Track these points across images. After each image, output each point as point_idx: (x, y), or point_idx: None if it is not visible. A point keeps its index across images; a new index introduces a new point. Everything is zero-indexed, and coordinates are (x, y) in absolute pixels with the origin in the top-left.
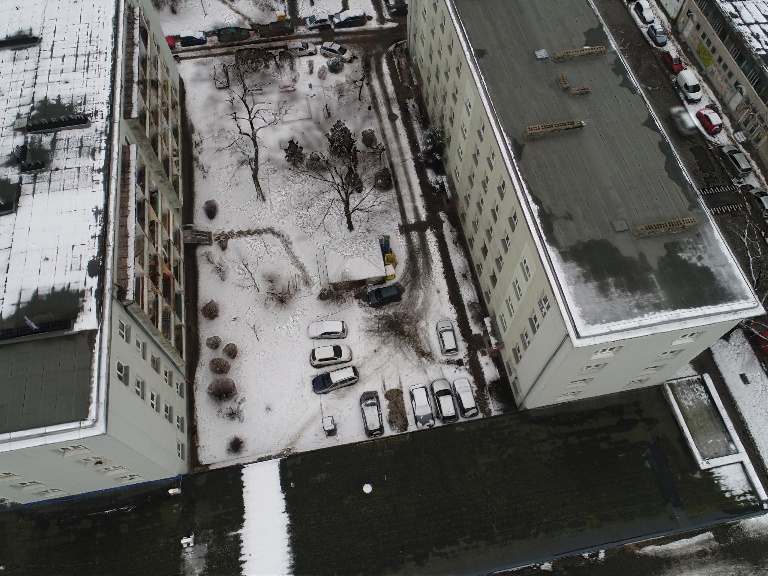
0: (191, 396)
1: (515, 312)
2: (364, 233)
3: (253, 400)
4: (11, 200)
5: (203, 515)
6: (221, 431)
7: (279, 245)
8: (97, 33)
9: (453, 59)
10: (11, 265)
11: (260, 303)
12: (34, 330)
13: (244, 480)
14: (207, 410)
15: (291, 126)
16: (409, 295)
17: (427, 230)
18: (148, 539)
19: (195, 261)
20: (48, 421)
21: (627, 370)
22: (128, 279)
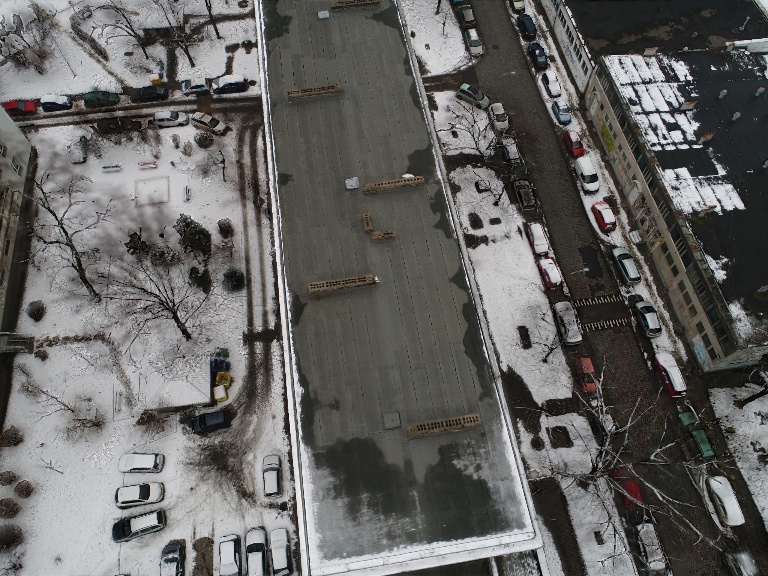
0: None
1: None
2: (203, 343)
3: (43, 548)
4: None
5: None
6: None
7: (106, 355)
8: None
9: None
10: None
11: None
12: None
13: None
14: None
15: (145, 210)
16: (241, 420)
17: (273, 341)
18: None
19: (10, 372)
20: None
21: None
22: None
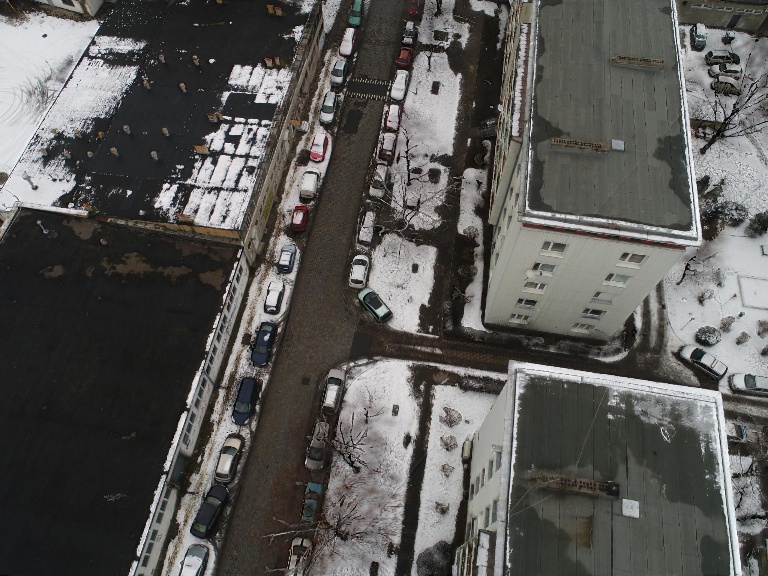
0: None
1: None
2: None
3: None
4: None
5: None
6: None
7: None
8: None
9: None
10: None
11: None
12: None
13: None
14: None
15: (762, 274)
16: None
17: None
18: None
19: None
20: None
21: None
22: None
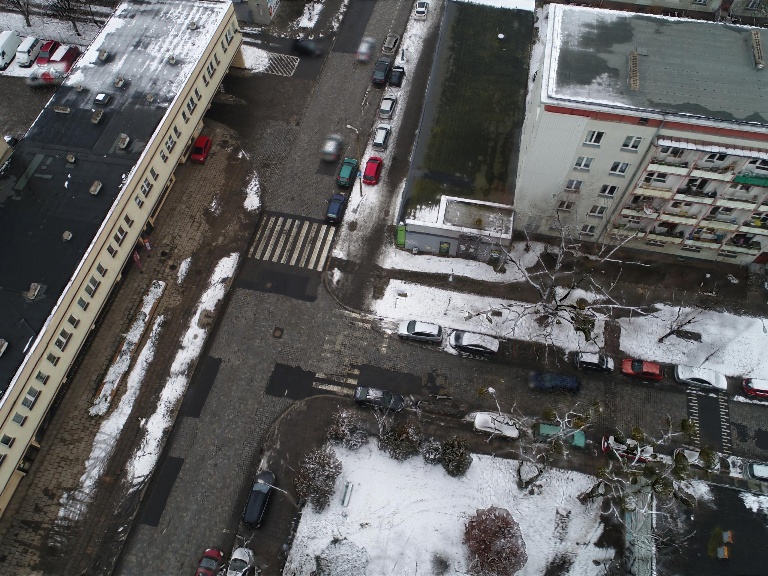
0: None
1: None
2: None
3: None
4: None
5: None
6: None
7: None
8: None
9: None
10: None
11: None
12: None
13: None
14: None
15: None
16: None
17: None
18: None
19: None
20: None
21: None
22: None
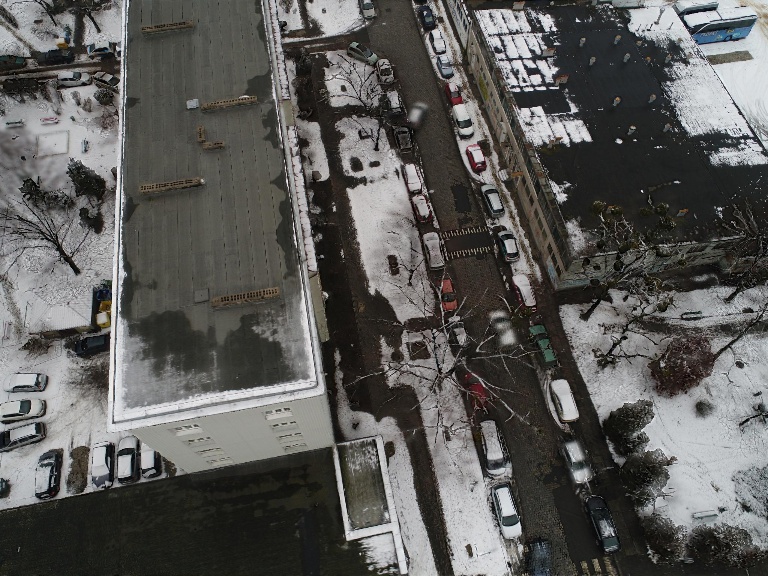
0: None
1: None
2: (91, 277)
3: None
4: None
5: None
6: None
7: None
8: None
9: None
10: None
11: None
12: None
13: None
14: None
15: (44, 161)
16: None
17: None
18: None
19: None
20: None
21: (254, 440)
22: None
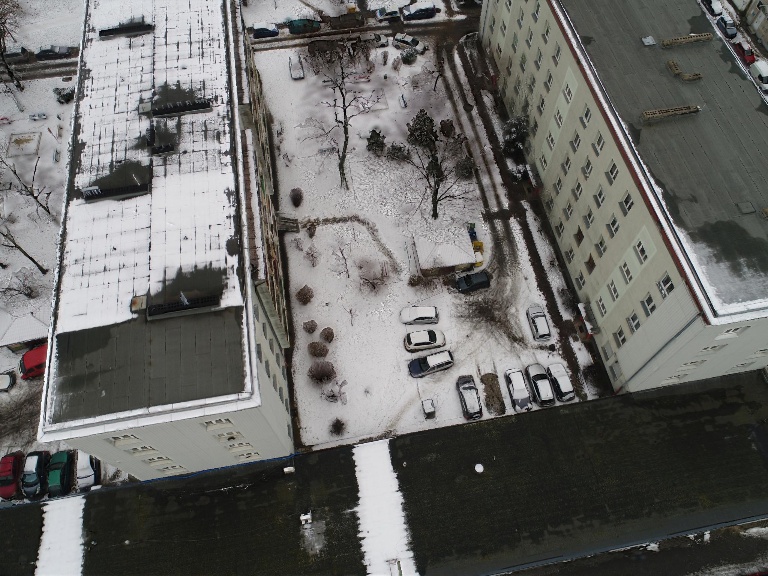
0: (290, 379)
1: (621, 296)
2: (448, 221)
3: (351, 383)
4: (144, 181)
5: (318, 493)
6: (322, 413)
7: (365, 232)
8: (208, 21)
9: (549, 47)
10: (153, 244)
11: (351, 289)
12: (185, 306)
13: (355, 459)
14: (306, 393)
15: (368, 116)
16: (497, 282)
17: (510, 218)
18: (266, 516)
19: (284, 248)
20: (206, 393)
21: (740, 352)
22: (258, 259)
